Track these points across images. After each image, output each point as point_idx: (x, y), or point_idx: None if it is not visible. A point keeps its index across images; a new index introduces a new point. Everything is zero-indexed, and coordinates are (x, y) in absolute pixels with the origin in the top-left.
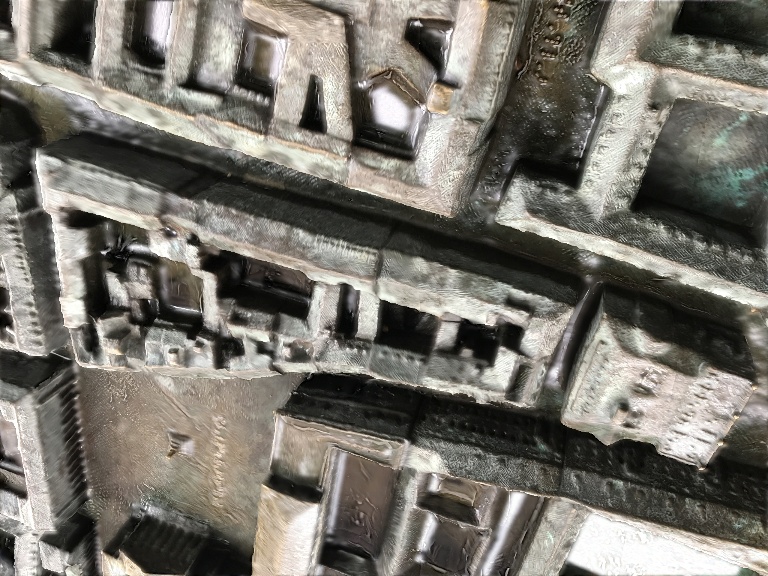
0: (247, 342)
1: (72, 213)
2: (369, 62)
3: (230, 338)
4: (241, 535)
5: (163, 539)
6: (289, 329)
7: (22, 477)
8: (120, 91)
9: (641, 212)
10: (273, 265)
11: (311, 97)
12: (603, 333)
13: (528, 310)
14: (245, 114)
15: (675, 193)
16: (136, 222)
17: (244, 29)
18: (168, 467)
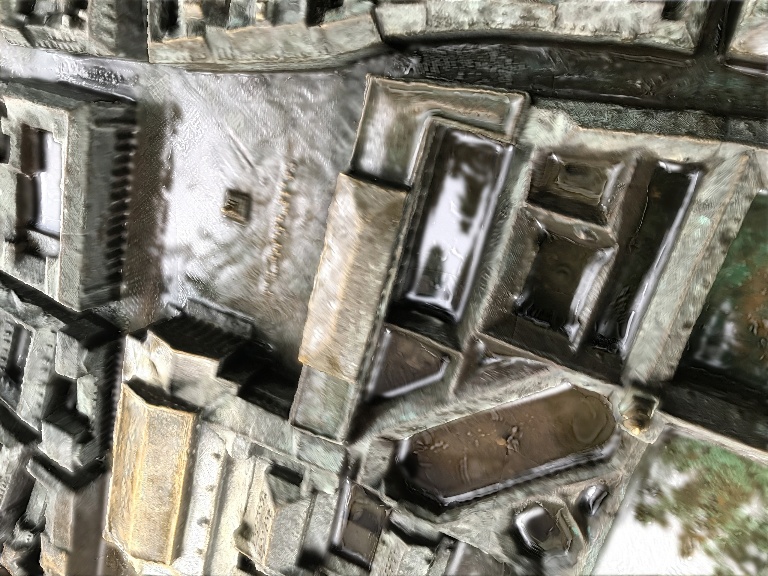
0: None
1: None
2: None
3: None
4: (288, 337)
5: (198, 332)
6: None
7: (56, 240)
8: None
9: None
10: None
11: None
12: None
13: None
14: None
15: None
16: None
17: None
18: (218, 244)
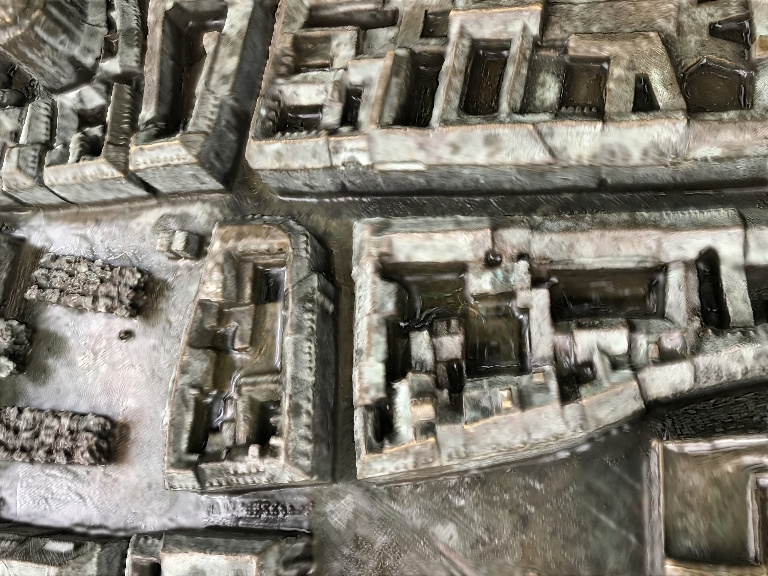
0: (599, 356)
1: (384, 268)
2: (683, 58)
3: (569, 371)
4: None
5: None
6: (649, 328)
7: None
8: (461, 126)
9: None
10: (597, 298)
11: (638, 91)
12: None
13: None
14: (578, 118)
15: None
16: (461, 251)
17: (565, 71)
18: None
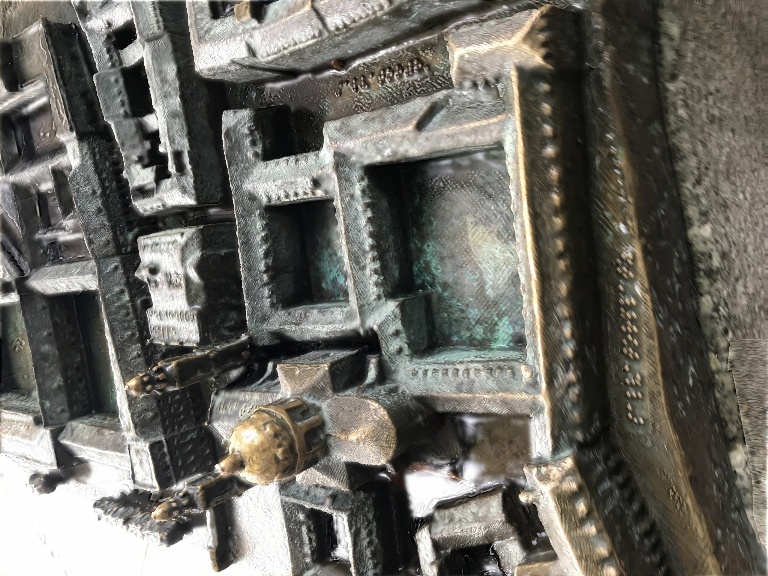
0: None
1: None
2: None
3: None
4: None
5: None
6: None
7: None
8: None
9: (268, 215)
10: None
11: None
12: (188, 232)
13: (179, 171)
14: None
15: (313, 237)
16: None
17: None
18: None
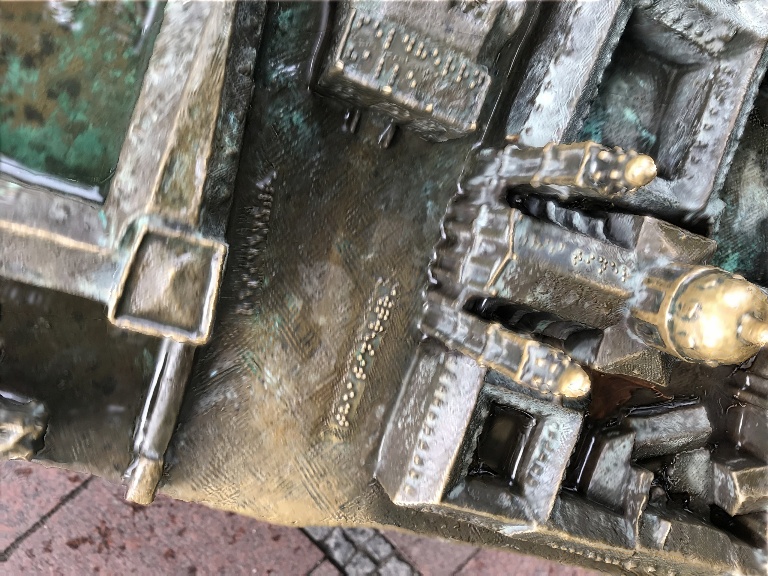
0: None
1: None
2: None
3: None
4: None
5: None
6: None
7: None
8: None
9: None
10: None
11: None
12: None
13: None
14: None
15: None
16: None
17: None
18: None
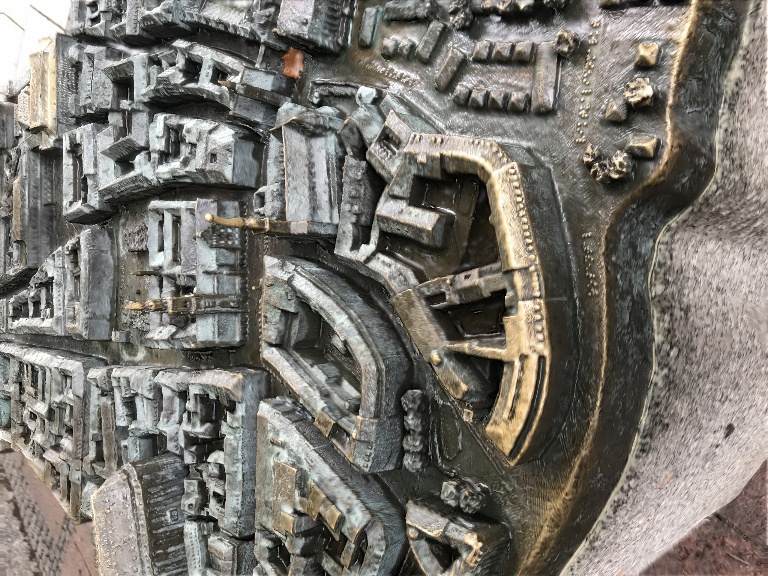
0: None
1: None
2: None
3: None
4: None
5: None
6: None
7: (78, 156)
8: None
9: None
10: None
11: None
12: (4, 330)
13: None
14: None
15: None
16: None
17: None
18: None
